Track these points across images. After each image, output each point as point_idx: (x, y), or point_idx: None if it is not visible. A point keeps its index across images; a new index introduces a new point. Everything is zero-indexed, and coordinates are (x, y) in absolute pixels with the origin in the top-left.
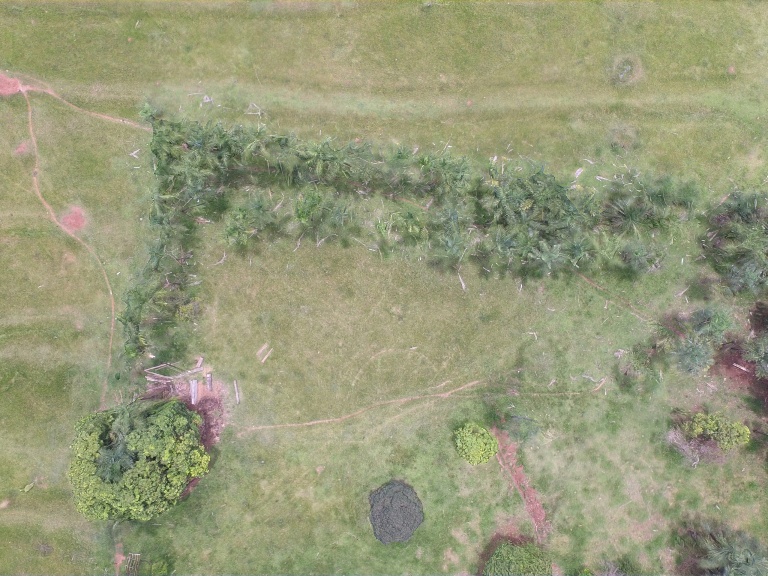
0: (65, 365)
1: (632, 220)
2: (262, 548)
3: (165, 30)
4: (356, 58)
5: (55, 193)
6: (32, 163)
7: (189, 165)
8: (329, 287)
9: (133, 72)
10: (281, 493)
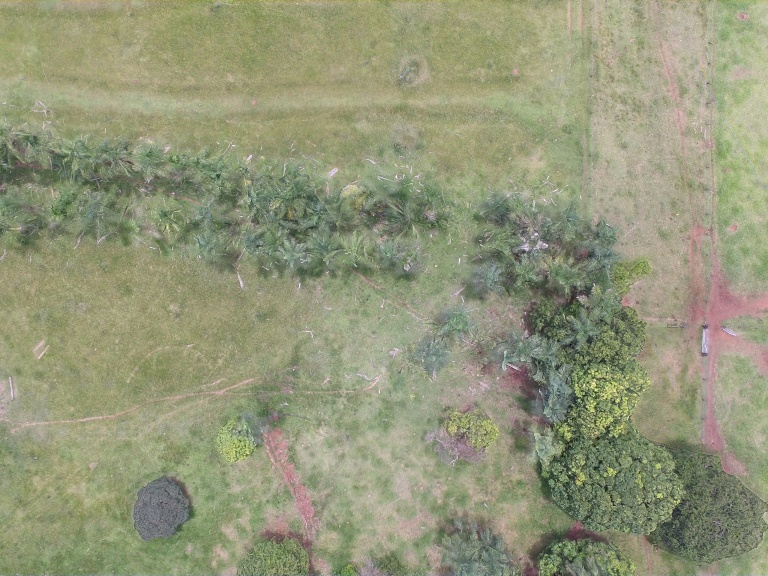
0: None
1: (411, 220)
2: (33, 544)
3: None
4: (144, 57)
5: None
6: None
7: None
8: (108, 284)
9: None
10: (53, 489)
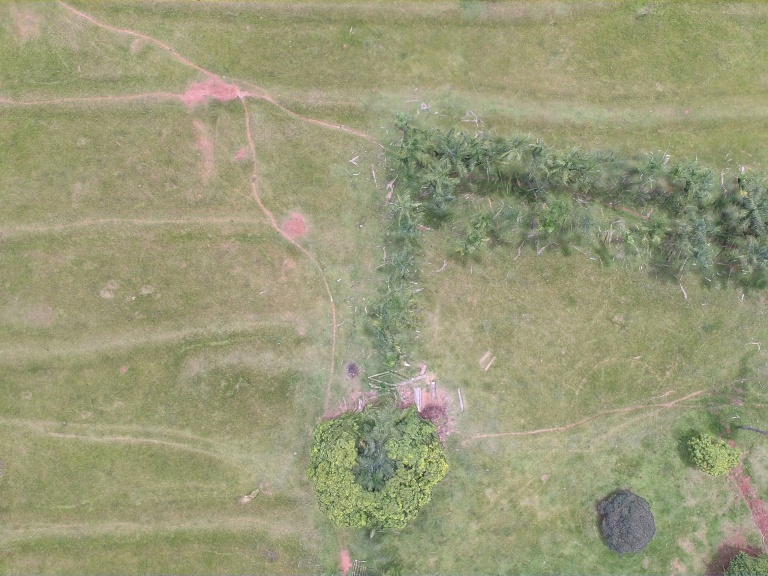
0: (288, 371)
1: None
2: (488, 556)
3: (380, 37)
4: (571, 66)
5: (275, 199)
6: (251, 169)
7: (439, 173)
8: (551, 295)
9: (349, 79)
10: (506, 501)
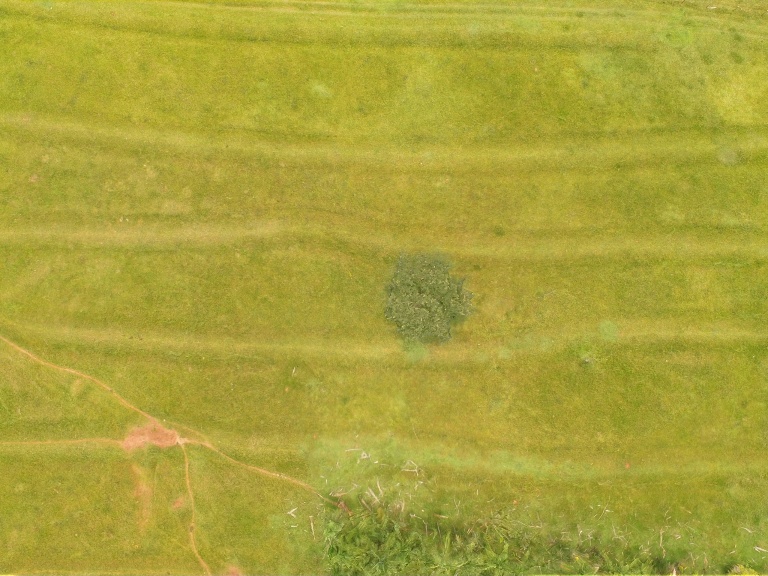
0: None
1: None
2: None
3: (322, 380)
4: (513, 414)
5: (212, 551)
6: (189, 518)
7: None
8: None
9: (290, 423)
10: None
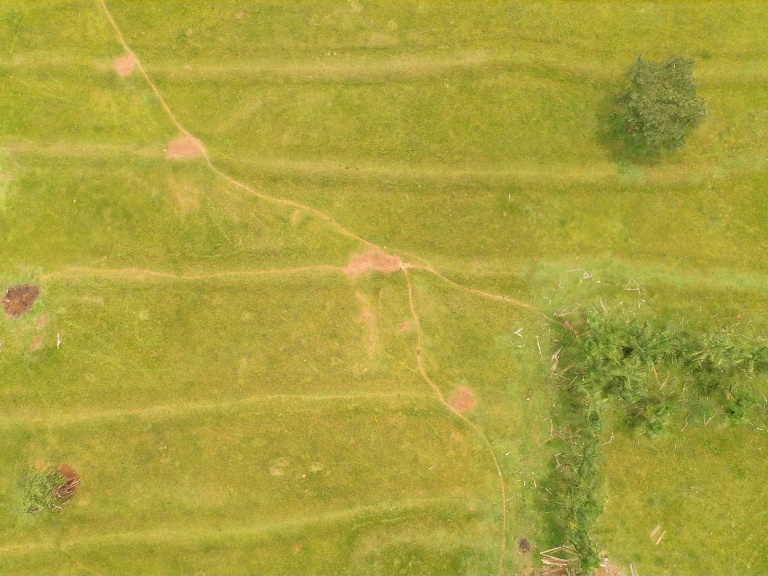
0: (460, 548)
1: None
2: None
3: (539, 204)
4: (731, 232)
5: (441, 372)
6: (415, 342)
7: (628, 369)
8: (719, 467)
9: (509, 247)
10: None
